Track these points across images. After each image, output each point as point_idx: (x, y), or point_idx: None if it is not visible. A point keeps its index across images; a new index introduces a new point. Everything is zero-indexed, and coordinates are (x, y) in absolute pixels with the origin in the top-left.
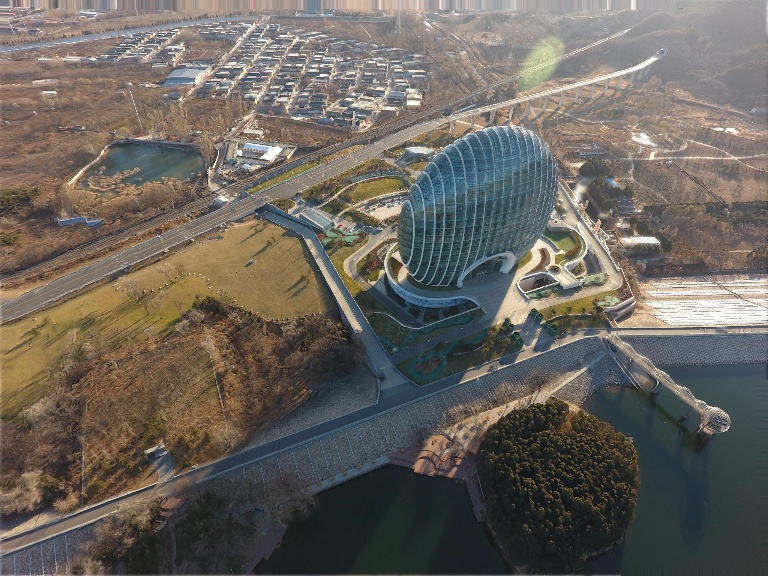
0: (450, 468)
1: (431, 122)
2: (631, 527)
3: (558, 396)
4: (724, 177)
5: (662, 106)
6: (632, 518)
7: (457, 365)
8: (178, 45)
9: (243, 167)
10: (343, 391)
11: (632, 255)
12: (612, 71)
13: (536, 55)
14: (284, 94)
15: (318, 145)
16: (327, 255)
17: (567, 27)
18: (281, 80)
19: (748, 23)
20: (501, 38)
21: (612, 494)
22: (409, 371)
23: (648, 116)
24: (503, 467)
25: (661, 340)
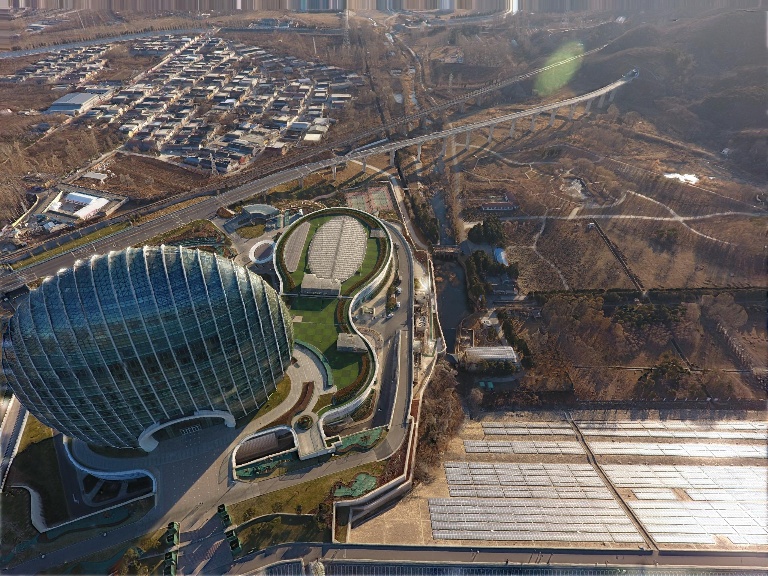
0: None
1: (302, 167)
2: None
3: None
4: (655, 247)
5: (610, 144)
6: None
7: None
8: (97, 63)
9: (44, 227)
10: None
11: (478, 372)
12: (573, 96)
13: (492, 75)
14: (168, 125)
15: (153, 197)
16: None
17: (539, 41)
18: (176, 107)
19: (744, 39)
20: (462, 54)
21: None
22: None
23: (583, 159)
24: None
25: (401, 570)
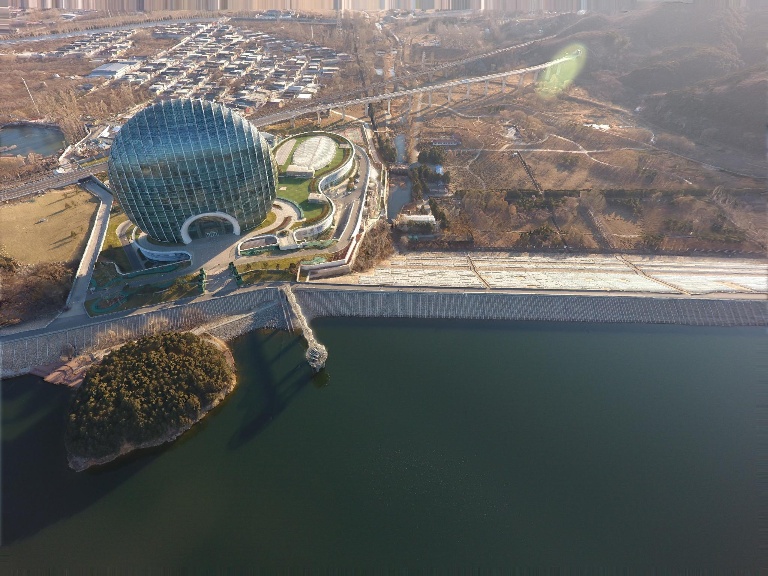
0: (76, 379)
1: (294, 111)
2: (204, 435)
3: (211, 333)
4: (560, 168)
5: (545, 103)
6: (179, 420)
7: (134, 303)
8: (126, 43)
9: (99, 146)
10: (40, 321)
11: None
12: None
13: (462, 55)
14: (188, 86)
15: None
16: (108, 217)
17: (507, 29)
18: (194, 74)
19: (676, 25)
20: (440, 39)
21: (165, 399)
22: (91, 305)
23: (519, 111)
24: (94, 375)
25: (336, 294)
